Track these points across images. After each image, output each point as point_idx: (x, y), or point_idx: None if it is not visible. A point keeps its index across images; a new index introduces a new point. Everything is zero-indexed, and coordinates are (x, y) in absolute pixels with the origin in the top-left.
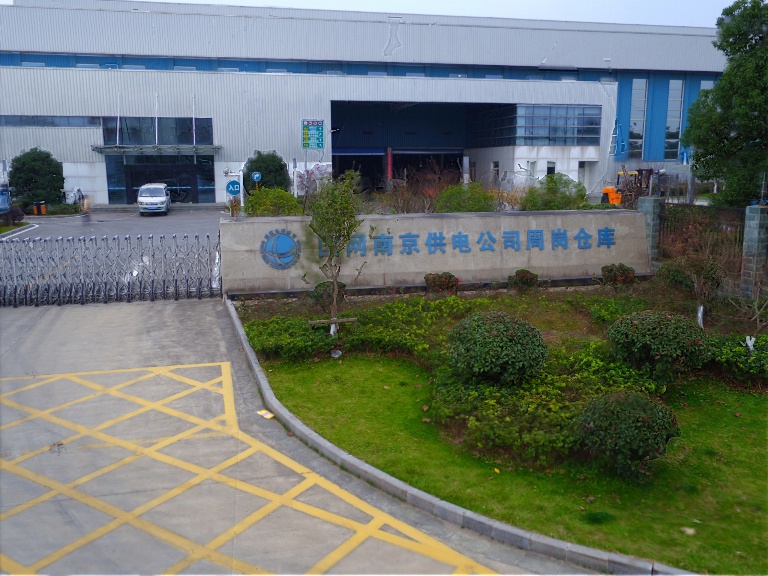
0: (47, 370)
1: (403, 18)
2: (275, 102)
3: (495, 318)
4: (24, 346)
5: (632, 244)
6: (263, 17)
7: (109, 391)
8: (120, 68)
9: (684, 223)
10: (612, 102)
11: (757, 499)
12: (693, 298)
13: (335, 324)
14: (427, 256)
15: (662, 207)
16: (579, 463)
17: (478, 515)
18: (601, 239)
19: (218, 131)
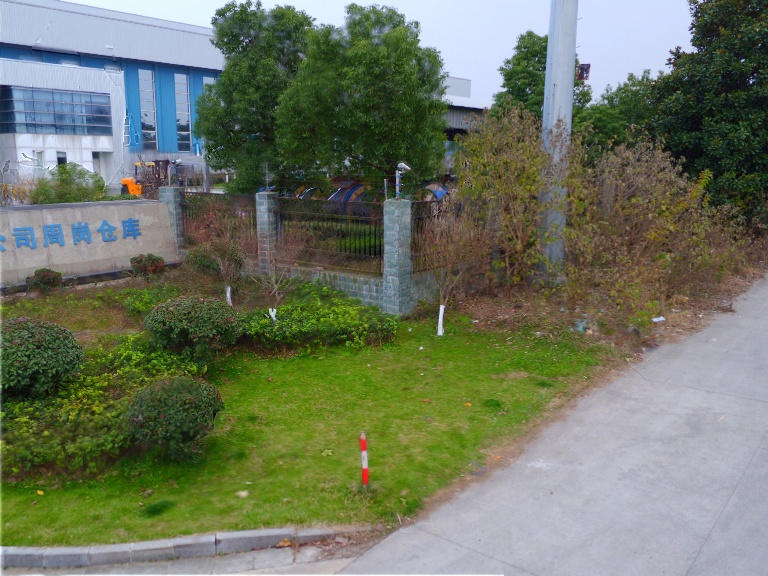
0: None
1: None
2: None
3: (16, 325)
4: None
5: (158, 234)
6: None
7: None
8: None
9: (204, 211)
10: (120, 91)
11: (294, 449)
12: (221, 280)
13: None
14: None
15: (182, 196)
16: (132, 460)
17: (23, 548)
18: (126, 230)
19: None
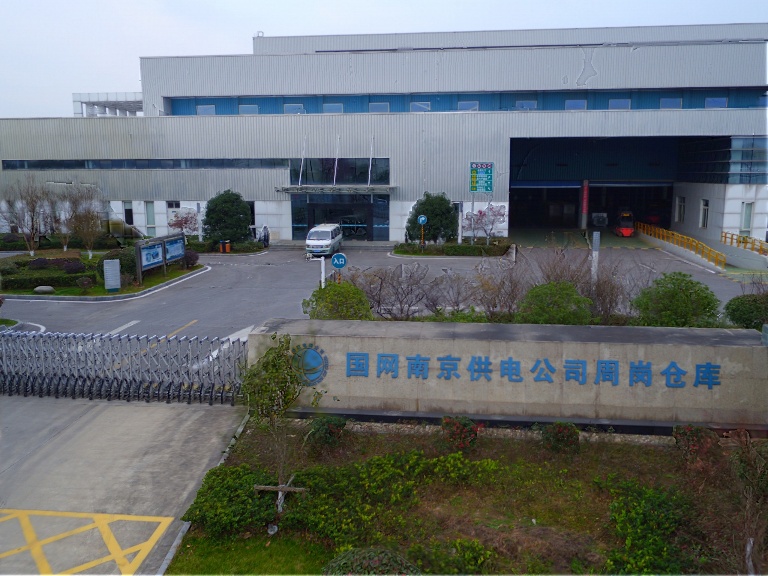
0: (15, 502)
1: (599, 45)
2: (452, 141)
3: (361, 569)
4: (31, 460)
5: (746, 386)
6: (456, 50)
7: (34, 546)
8: (308, 113)
9: None
10: None
11: None
12: (765, 508)
13: (282, 492)
14: (469, 383)
15: None
16: None
17: None
18: (700, 377)
19: (395, 171)
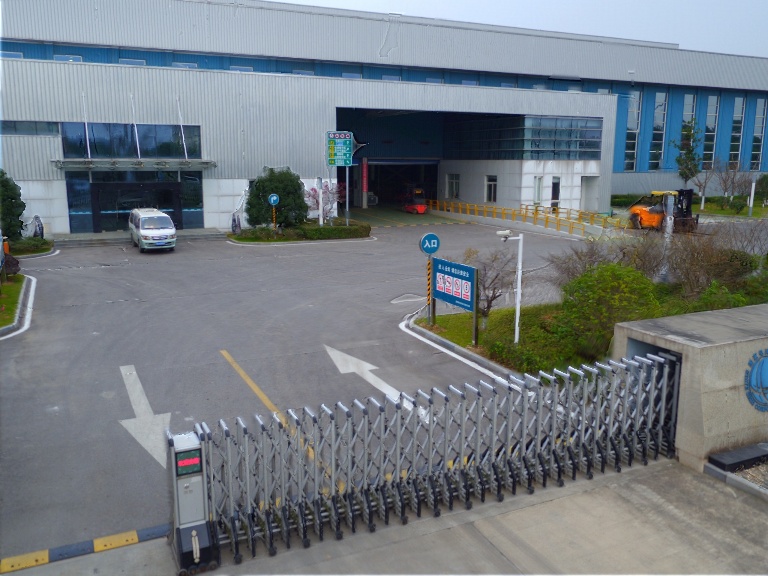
0: None
1: None
2: (274, 108)
3: None
4: None
5: None
6: (229, 5)
7: None
8: (85, 61)
9: None
10: (612, 115)
11: None
12: None
13: None
14: None
15: None
16: None
17: None
18: None
19: (207, 142)
